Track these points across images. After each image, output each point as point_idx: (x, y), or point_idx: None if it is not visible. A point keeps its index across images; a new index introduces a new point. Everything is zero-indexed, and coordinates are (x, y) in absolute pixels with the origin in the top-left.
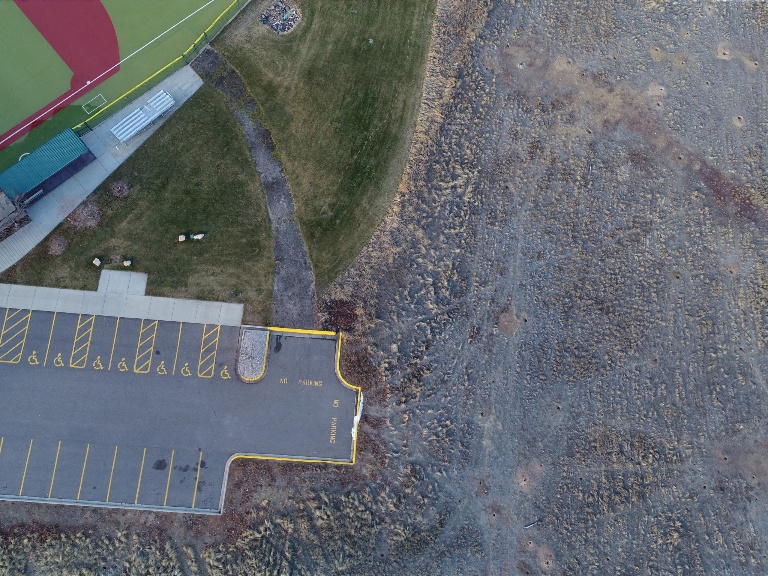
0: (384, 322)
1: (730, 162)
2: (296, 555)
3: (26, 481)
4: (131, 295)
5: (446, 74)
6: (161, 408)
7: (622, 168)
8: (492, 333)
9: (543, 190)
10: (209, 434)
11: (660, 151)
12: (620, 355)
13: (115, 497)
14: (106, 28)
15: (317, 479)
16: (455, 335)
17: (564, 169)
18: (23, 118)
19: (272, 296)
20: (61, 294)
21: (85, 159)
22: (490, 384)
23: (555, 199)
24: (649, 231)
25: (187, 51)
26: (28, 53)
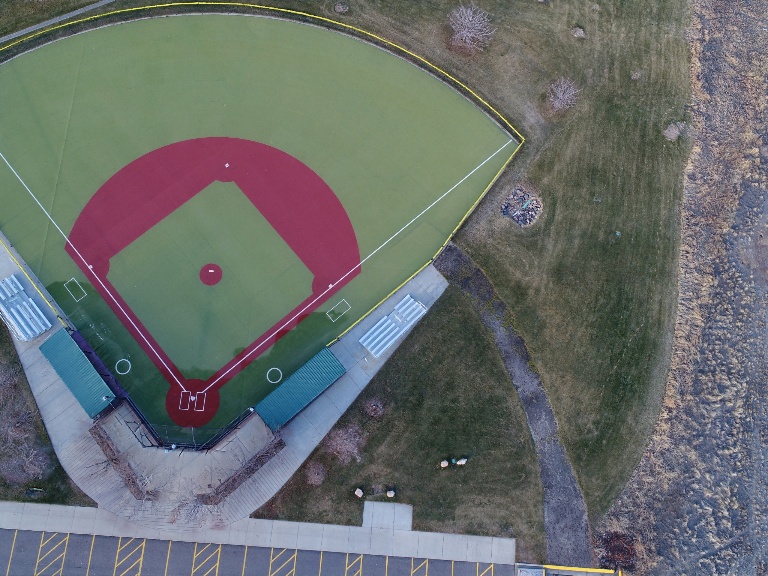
0: (665, 558)
1: None
2: None
3: None
4: (398, 530)
5: (700, 270)
6: None
7: None
8: None
9: None
10: None
11: None
12: None
13: None
14: (343, 224)
15: None
16: (742, 573)
17: None
18: (267, 328)
19: (544, 529)
20: (325, 530)
21: None
22: None
23: None
24: None
25: (436, 255)
26: (266, 254)
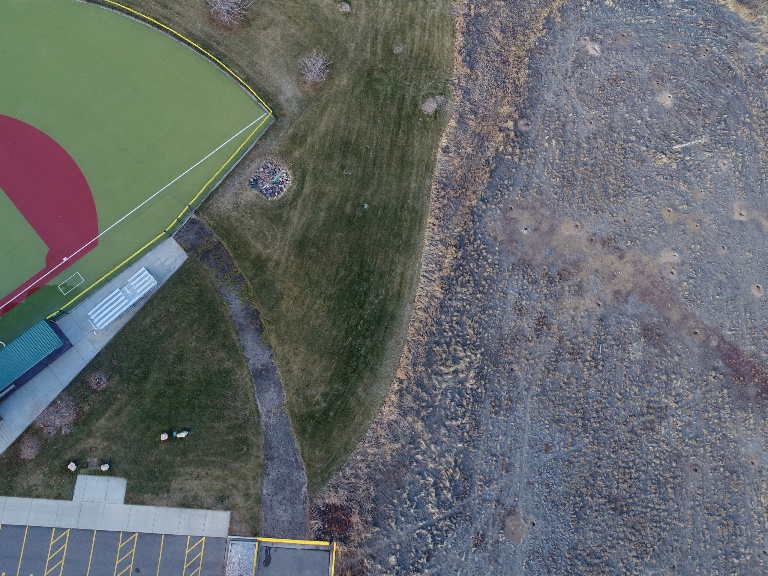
0: (381, 530)
1: (749, 337)
2: None
3: None
4: (109, 504)
5: (446, 242)
6: None
7: (634, 345)
8: (498, 540)
9: (551, 373)
10: None
11: (674, 325)
12: (635, 562)
13: None
14: (84, 197)
15: None
16: (458, 543)
17: (573, 348)
18: None
19: (261, 501)
20: (33, 505)
21: (61, 347)
22: None
23: (563, 382)
24: (664, 417)
25: (170, 226)
26: (1, 227)
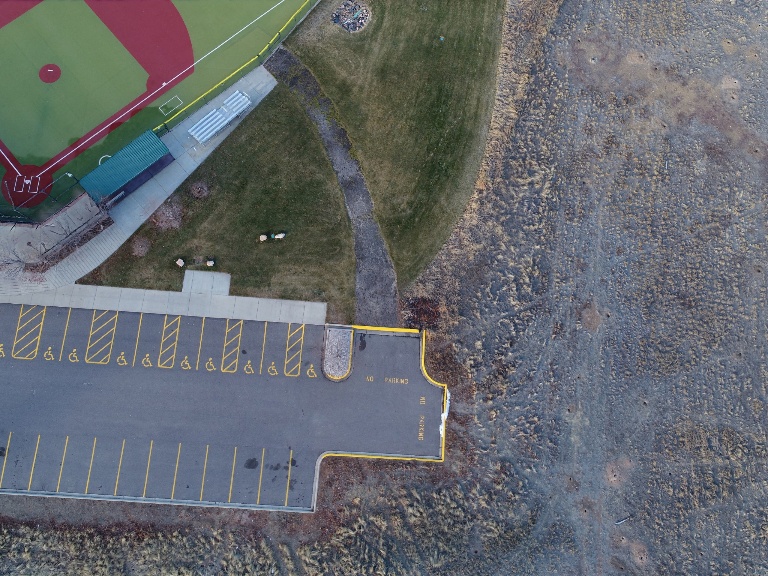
0: (467, 319)
1: None
2: (391, 552)
3: (120, 481)
4: (215, 295)
5: (518, 70)
6: (250, 407)
7: (698, 162)
8: (575, 329)
9: (620, 185)
10: (298, 433)
11: (736, 144)
12: (704, 350)
13: (208, 496)
14: (179, 30)
15: (408, 476)
16: (538, 331)
17: (640, 164)
18: (101, 120)
19: (355, 294)
20: (146, 295)
21: (164, 160)
22: (576, 380)
23: (632, 194)
24: (728, 225)
25: (262, 51)
26: (103, 56)
